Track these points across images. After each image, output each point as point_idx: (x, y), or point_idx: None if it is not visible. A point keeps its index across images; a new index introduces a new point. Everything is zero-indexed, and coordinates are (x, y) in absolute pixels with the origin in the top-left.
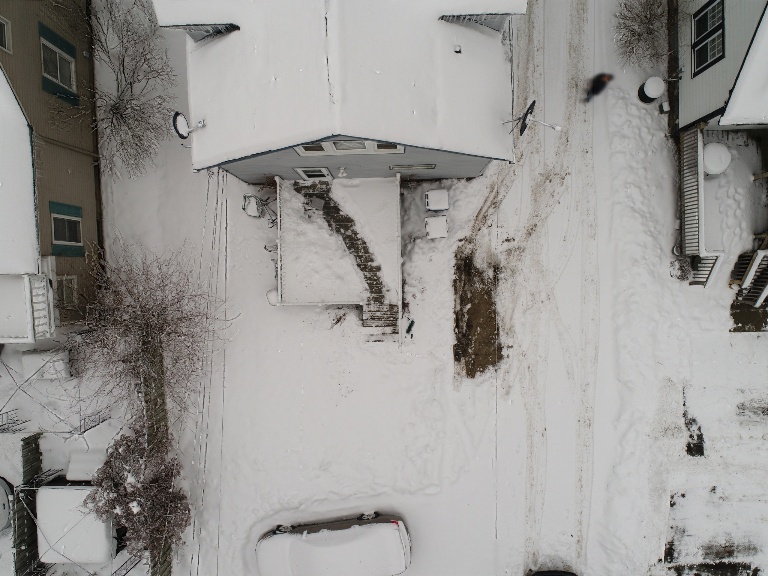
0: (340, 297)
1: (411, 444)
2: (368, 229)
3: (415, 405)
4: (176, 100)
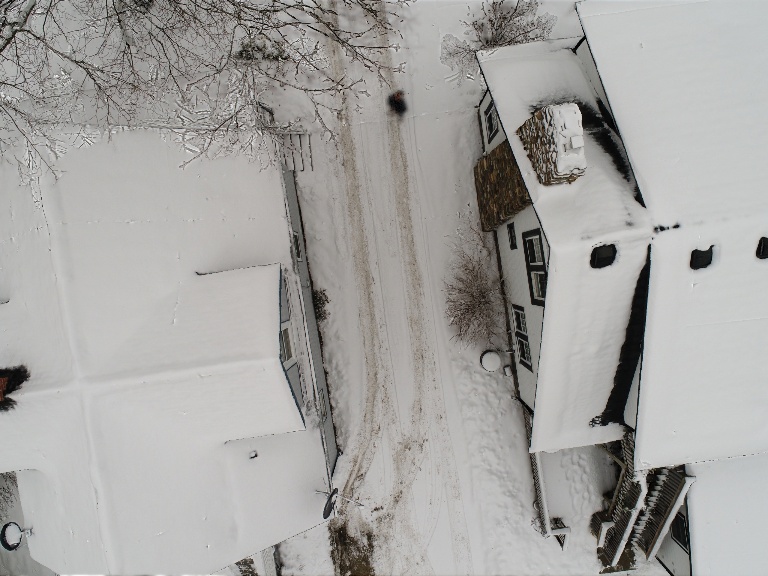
0: None
1: None
2: None
3: None
4: None
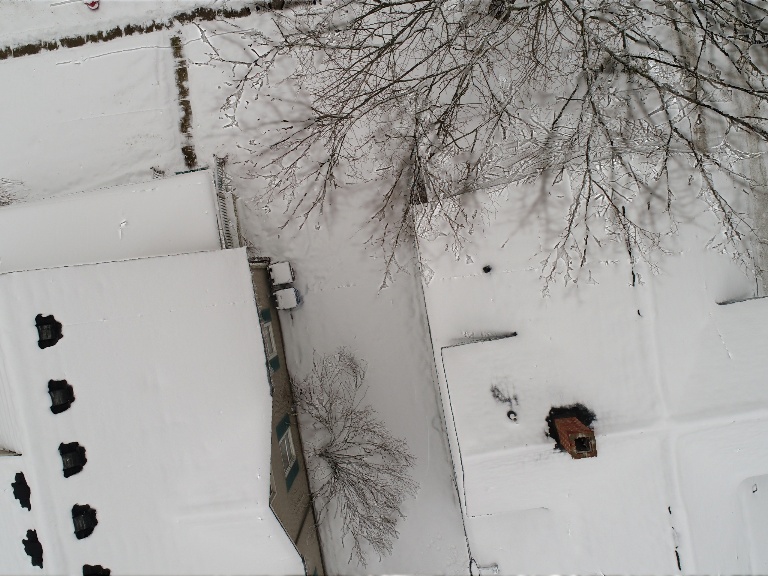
0: None
1: None
2: None
3: None
4: (407, 468)
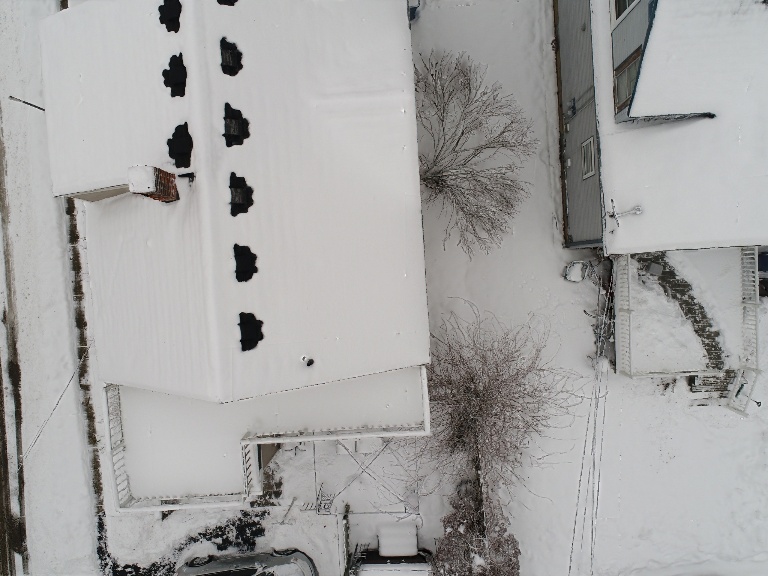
0: (683, 365)
1: (738, 510)
2: (711, 294)
3: (742, 470)
4: (522, 170)
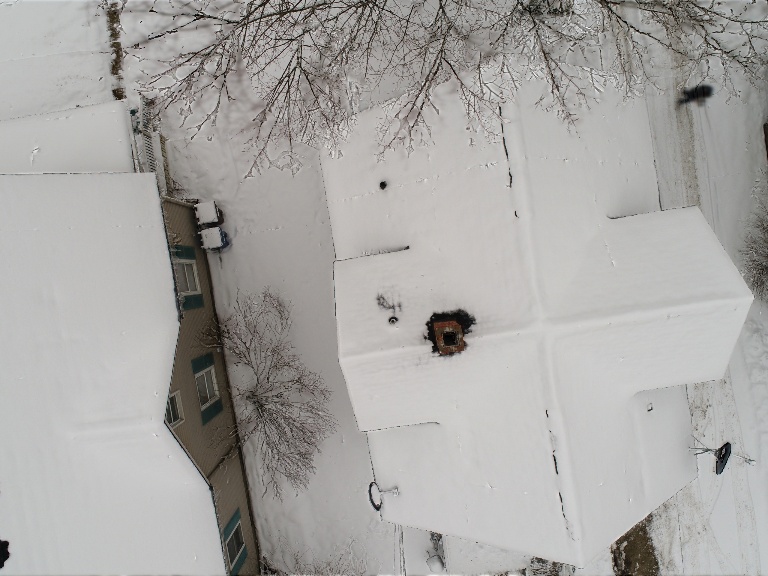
0: (506, 566)
1: None
2: None
3: None
4: (327, 405)
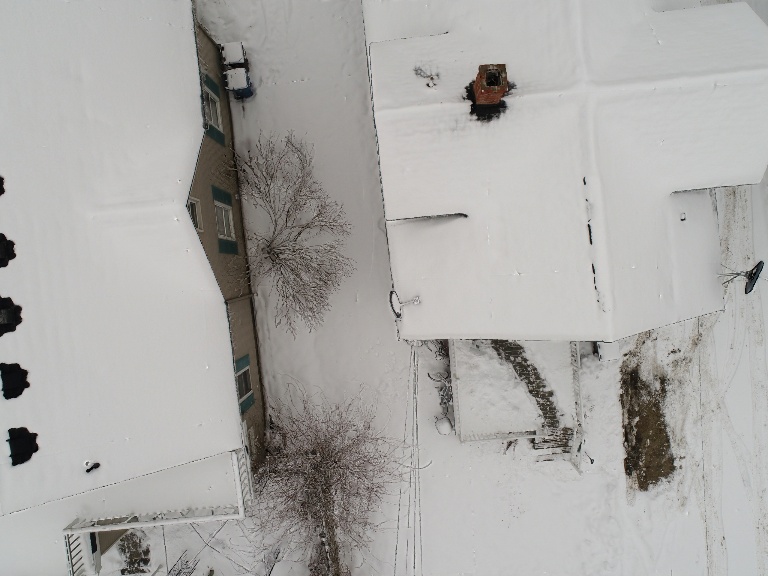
0: (517, 427)
1: (588, 561)
2: (540, 357)
3: (590, 522)
4: (345, 247)
